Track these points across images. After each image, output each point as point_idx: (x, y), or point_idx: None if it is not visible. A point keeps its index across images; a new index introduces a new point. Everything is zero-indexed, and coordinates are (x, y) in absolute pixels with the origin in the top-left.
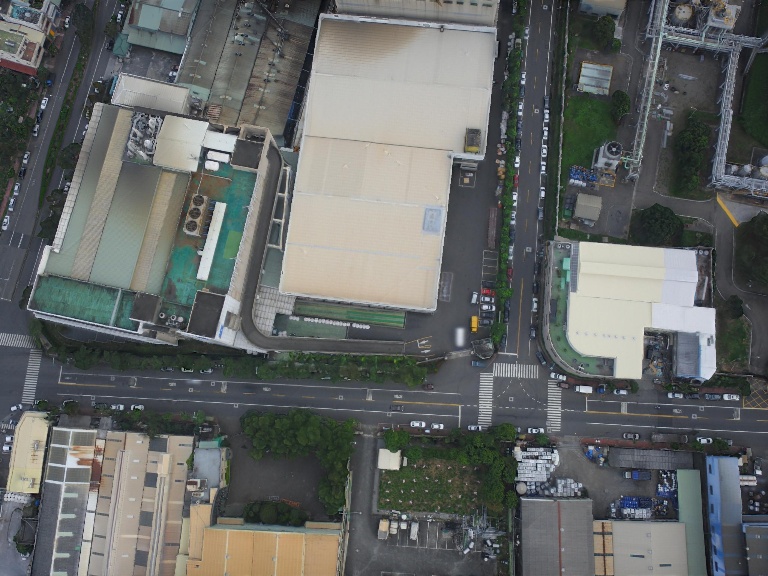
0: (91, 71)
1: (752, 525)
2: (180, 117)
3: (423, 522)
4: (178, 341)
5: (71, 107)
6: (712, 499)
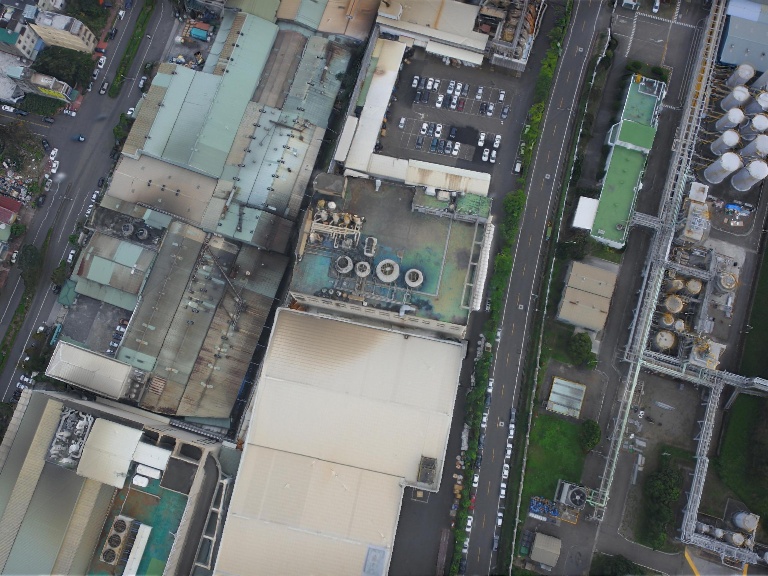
0: (34, 314)
1: None
2: (112, 422)
3: None
4: None
5: (7, 354)
6: None
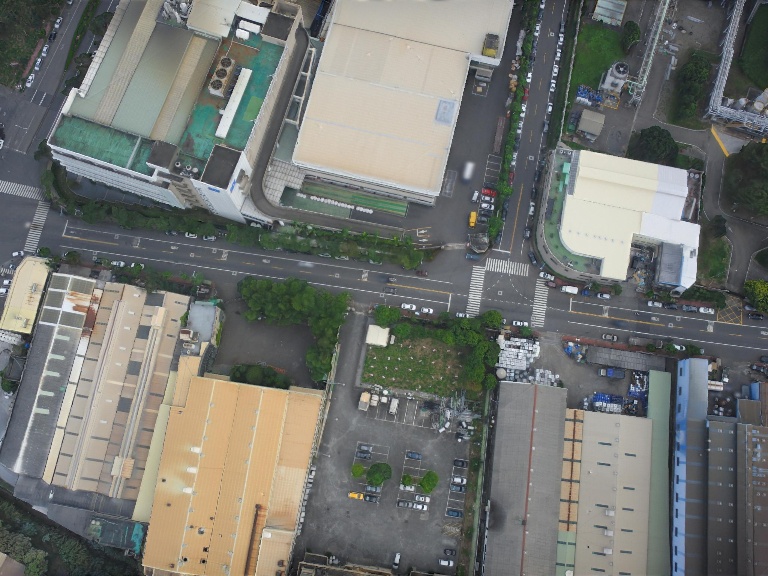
0: None
1: (716, 421)
2: None
3: (403, 399)
4: (185, 209)
5: None
6: (680, 399)
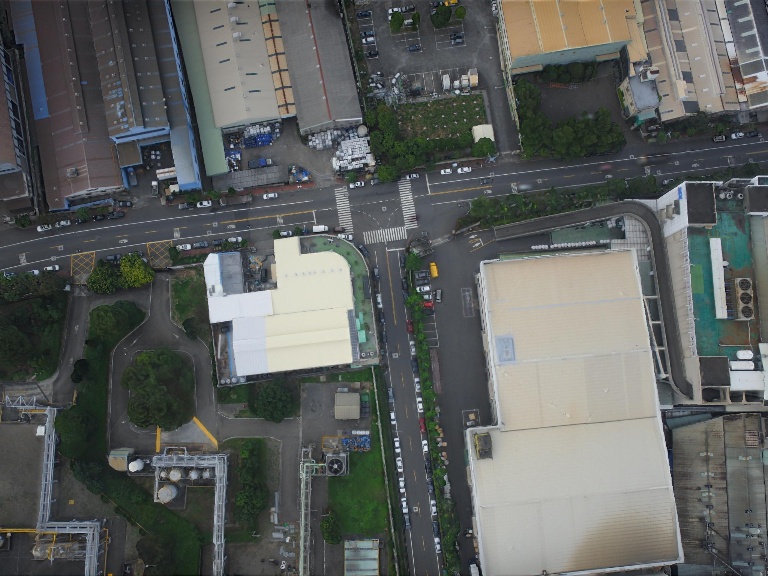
0: None
1: (162, 129)
2: None
3: (440, 91)
4: None
5: None
6: None
